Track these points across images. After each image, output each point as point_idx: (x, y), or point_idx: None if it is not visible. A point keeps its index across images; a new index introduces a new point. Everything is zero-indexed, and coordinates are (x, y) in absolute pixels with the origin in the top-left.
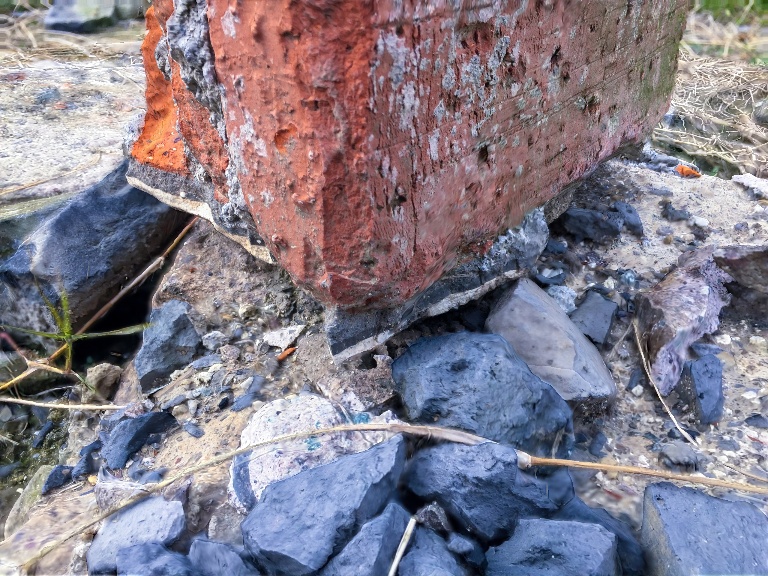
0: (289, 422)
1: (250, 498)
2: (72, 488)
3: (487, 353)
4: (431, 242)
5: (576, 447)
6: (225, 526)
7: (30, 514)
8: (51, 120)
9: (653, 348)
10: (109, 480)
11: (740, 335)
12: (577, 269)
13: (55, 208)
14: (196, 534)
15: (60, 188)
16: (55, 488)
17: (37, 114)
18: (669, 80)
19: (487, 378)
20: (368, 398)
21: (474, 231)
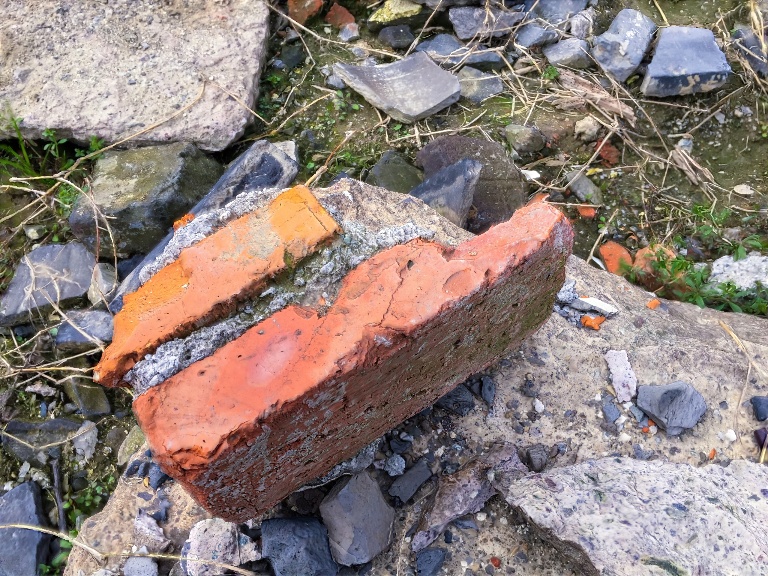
0: (208, 539)
1: (185, 570)
2: (138, 480)
3: (297, 544)
4: (269, 504)
5: (353, 568)
6: (176, 575)
7: (119, 486)
8: (173, 17)
9: (420, 526)
10: (141, 517)
11: (500, 511)
12: (427, 432)
13: (156, 195)
14: (164, 575)
15: (170, 133)
16: (131, 475)
17: (162, 6)
18: (540, 318)
19: (291, 559)
20: (256, 520)
21: (308, 480)
